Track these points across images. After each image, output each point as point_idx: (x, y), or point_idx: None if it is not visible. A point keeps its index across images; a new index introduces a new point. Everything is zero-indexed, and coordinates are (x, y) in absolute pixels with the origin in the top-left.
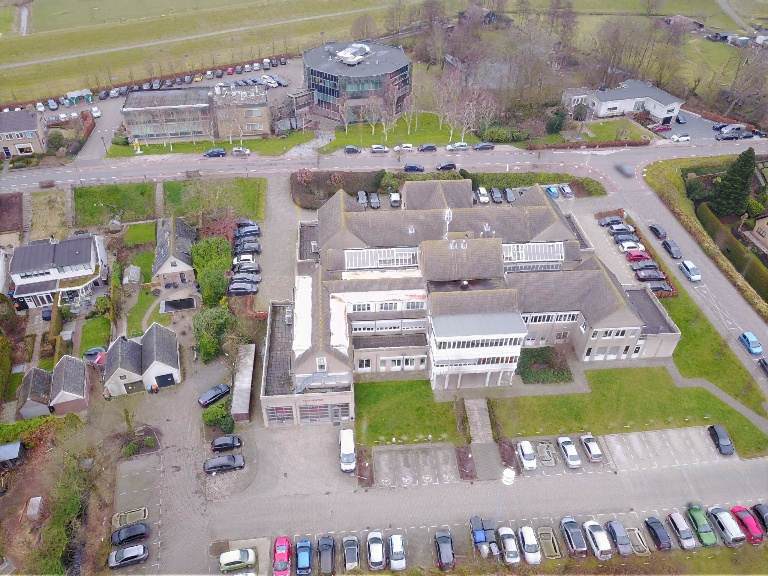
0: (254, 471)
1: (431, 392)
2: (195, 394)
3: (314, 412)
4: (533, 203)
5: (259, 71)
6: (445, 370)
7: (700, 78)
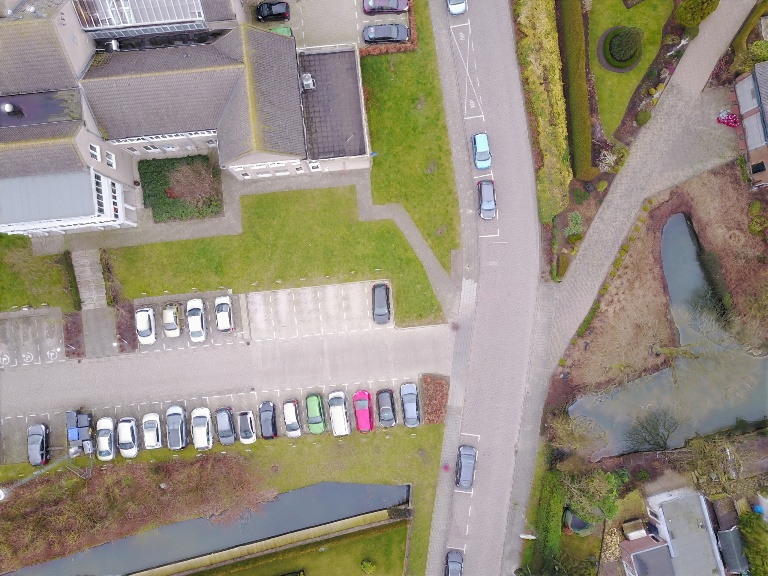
0: None
1: (28, 241)
2: None
3: None
4: None
5: None
6: (22, 232)
7: None
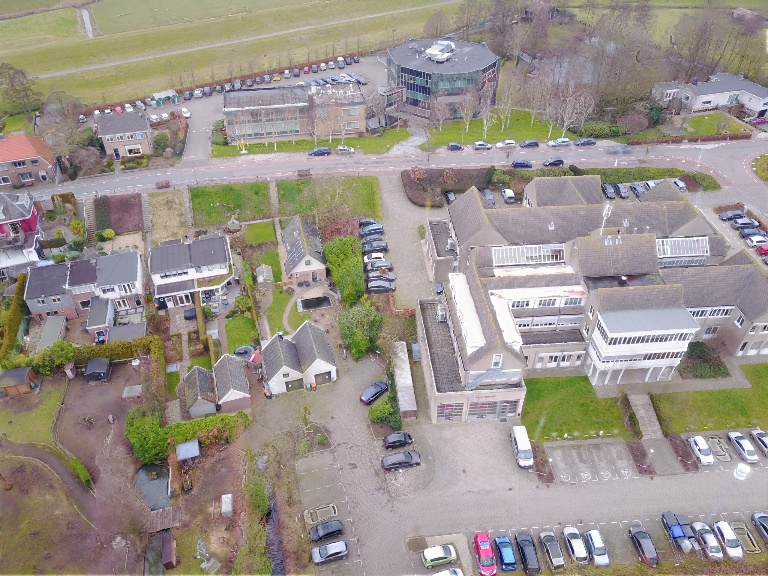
0: (432, 468)
1: (592, 388)
2: (353, 392)
3: (482, 409)
4: (666, 198)
5: (334, 69)
6: (610, 366)
7: None
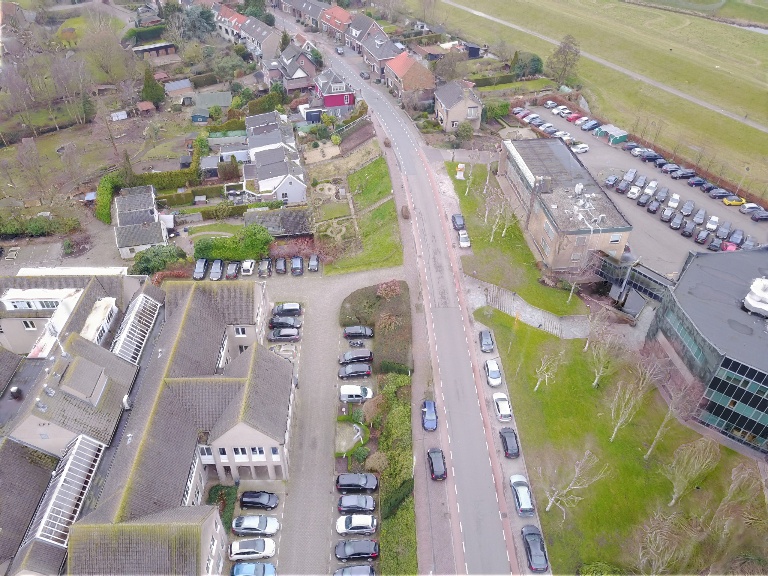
0: None
1: None
2: None
3: None
4: (162, 516)
5: None
6: None
7: None
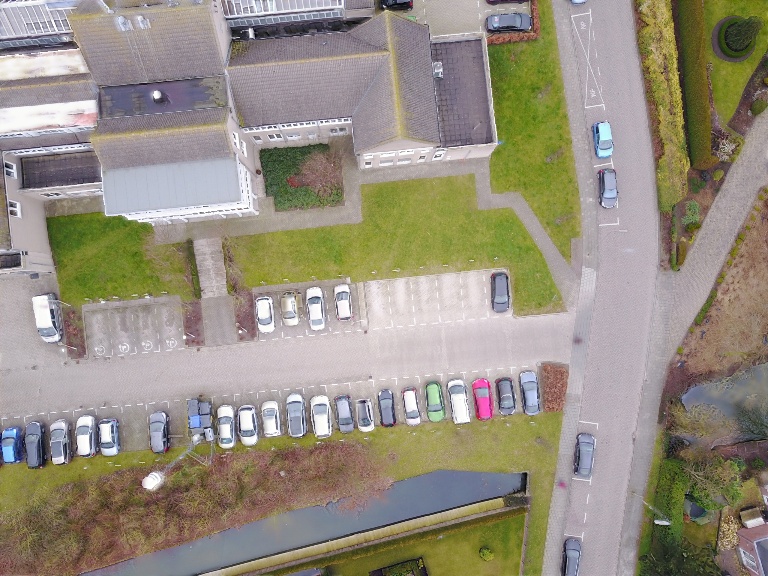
0: None
1: (151, 229)
2: None
3: None
4: None
5: None
6: (153, 219)
7: None
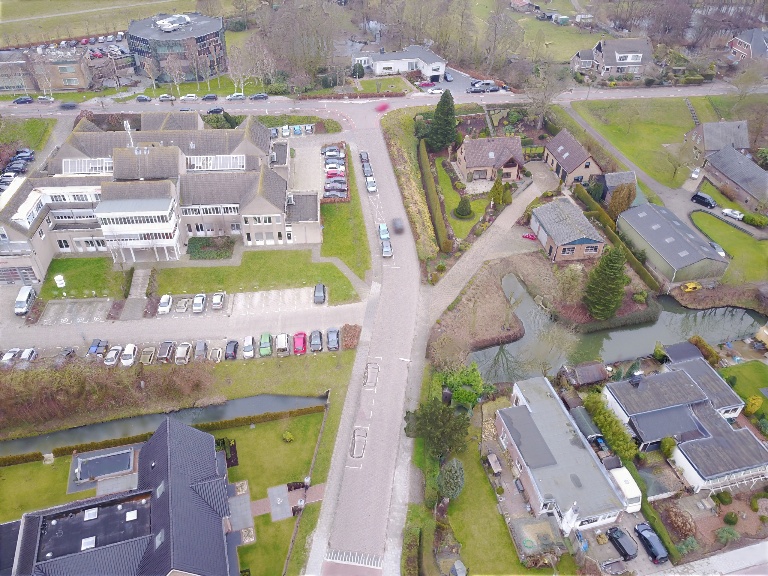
0: None
1: (112, 265)
2: None
3: (7, 275)
4: None
5: (112, 42)
6: (116, 244)
7: (490, 46)
